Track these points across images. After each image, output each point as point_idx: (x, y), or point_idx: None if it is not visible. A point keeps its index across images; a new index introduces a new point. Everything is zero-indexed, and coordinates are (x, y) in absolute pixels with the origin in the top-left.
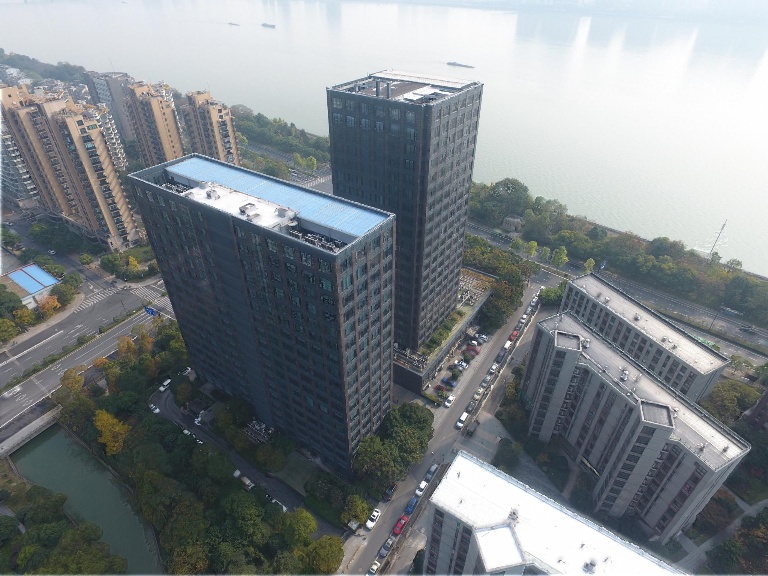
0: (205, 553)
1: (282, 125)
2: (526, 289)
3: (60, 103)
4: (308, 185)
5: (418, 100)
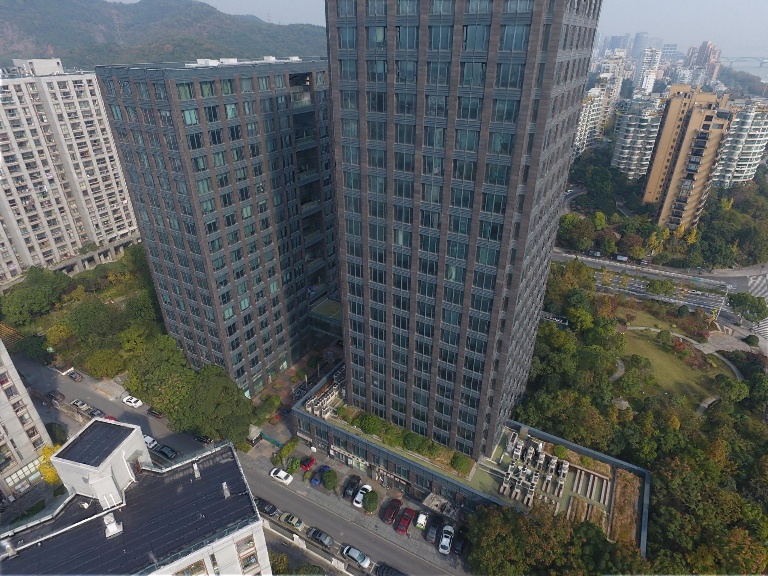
0: None
1: None
2: None
3: None
4: None
5: None
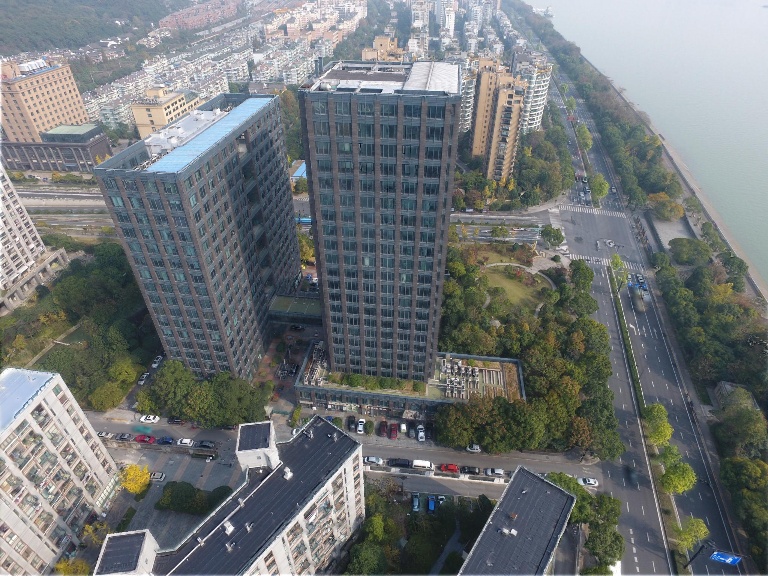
0: (96, 334)
1: (646, 144)
2: (573, 461)
3: (374, 53)
4: (574, 208)
5: (346, 90)
